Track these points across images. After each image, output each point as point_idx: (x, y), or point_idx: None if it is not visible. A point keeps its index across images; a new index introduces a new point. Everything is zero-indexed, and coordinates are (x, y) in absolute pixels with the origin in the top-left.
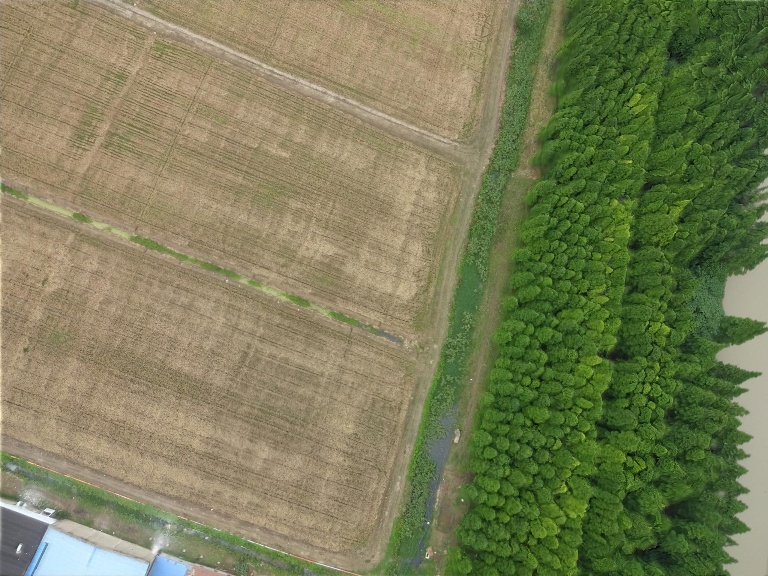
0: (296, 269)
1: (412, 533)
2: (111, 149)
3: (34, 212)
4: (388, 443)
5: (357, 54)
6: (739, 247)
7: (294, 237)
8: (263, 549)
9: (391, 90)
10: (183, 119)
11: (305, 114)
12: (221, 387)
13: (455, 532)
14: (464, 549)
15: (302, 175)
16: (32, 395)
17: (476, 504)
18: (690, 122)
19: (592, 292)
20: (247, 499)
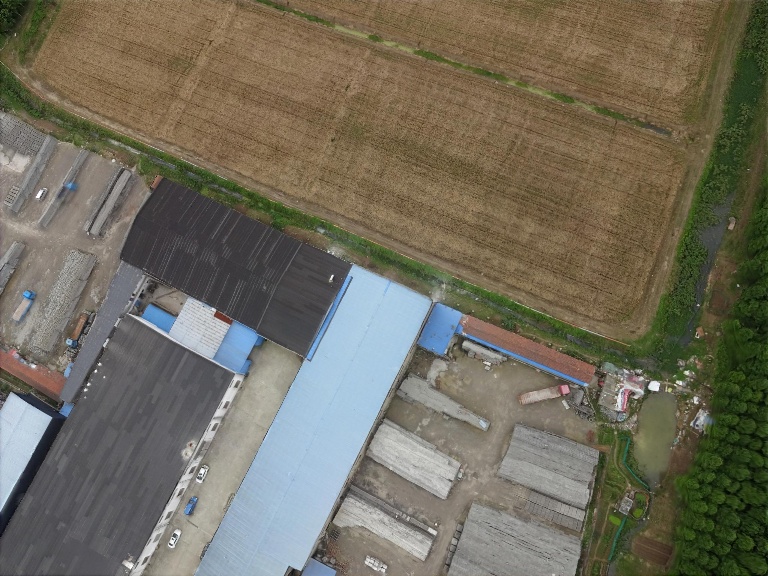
0: (561, 69)
1: (681, 311)
2: None
3: (340, 35)
4: (655, 225)
5: None
6: None
7: (559, 41)
8: (529, 311)
9: None
10: None
11: None
12: (491, 171)
13: (730, 313)
14: (743, 322)
15: None
16: (337, 174)
17: (758, 276)
18: None
19: None
20: (514, 267)
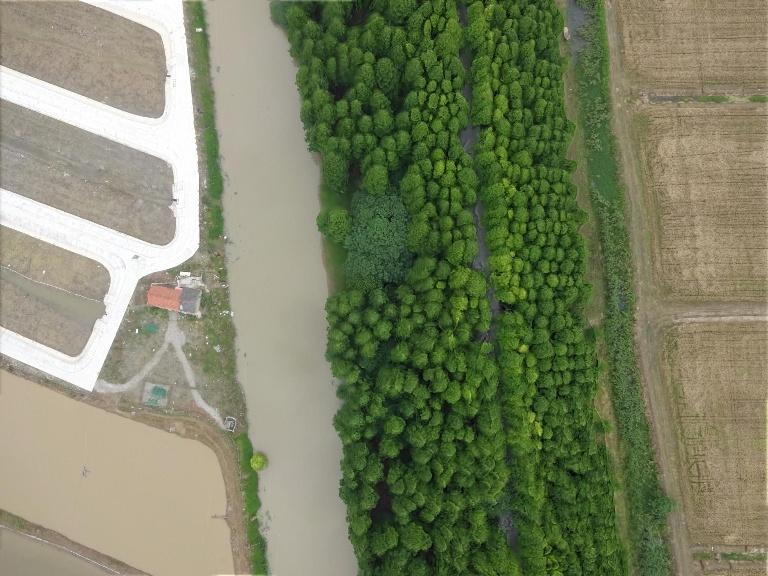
0: None
1: None
2: None
3: None
4: (629, 4)
5: None
6: (360, 309)
7: None
8: None
9: (767, 351)
10: None
11: None
12: None
13: None
14: None
15: None
16: None
17: None
18: (484, 412)
19: None
20: None
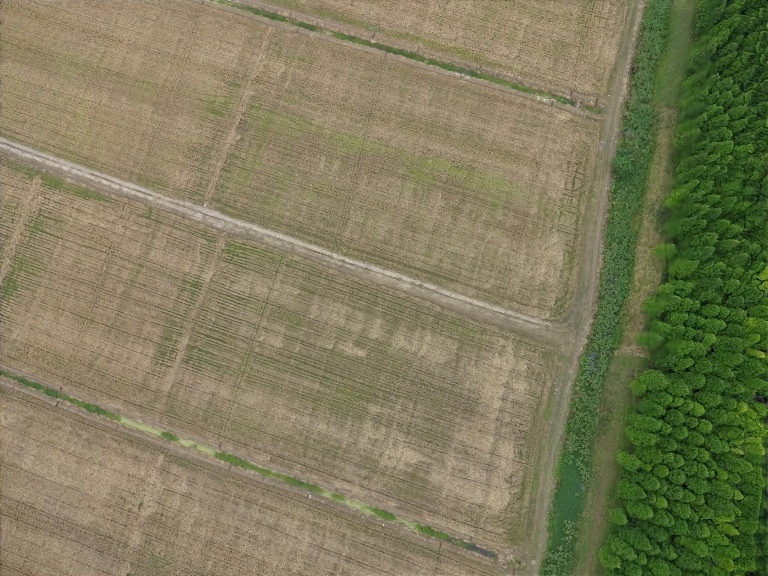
0: (379, 481)
1: None
2: (192, 363)
3: (126, 435)
4: None
5: (432, 230)
6: None
7: (375, 445)
8: None
9: (471, 268)
10: (257, 324)
11: (380, 306)
12: None
13: None
14: None
15: (380, 375)
16: None
17: None
18: None
19: (717, 519)
20: None
